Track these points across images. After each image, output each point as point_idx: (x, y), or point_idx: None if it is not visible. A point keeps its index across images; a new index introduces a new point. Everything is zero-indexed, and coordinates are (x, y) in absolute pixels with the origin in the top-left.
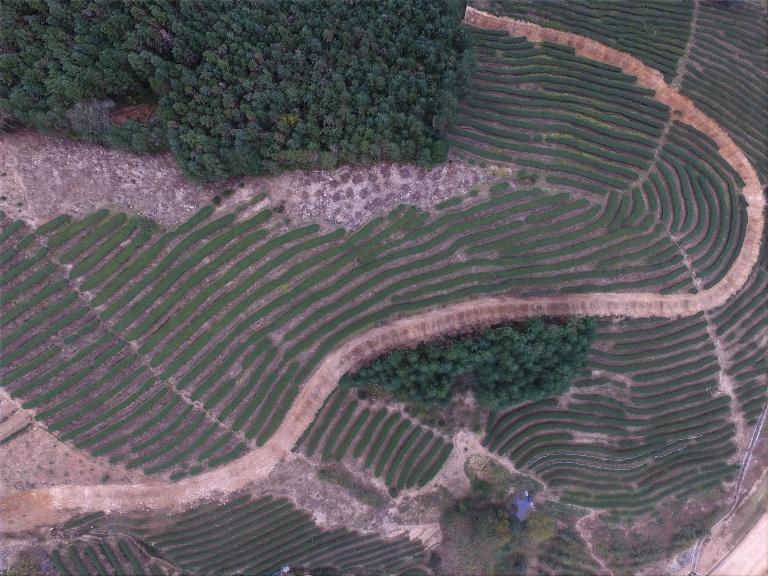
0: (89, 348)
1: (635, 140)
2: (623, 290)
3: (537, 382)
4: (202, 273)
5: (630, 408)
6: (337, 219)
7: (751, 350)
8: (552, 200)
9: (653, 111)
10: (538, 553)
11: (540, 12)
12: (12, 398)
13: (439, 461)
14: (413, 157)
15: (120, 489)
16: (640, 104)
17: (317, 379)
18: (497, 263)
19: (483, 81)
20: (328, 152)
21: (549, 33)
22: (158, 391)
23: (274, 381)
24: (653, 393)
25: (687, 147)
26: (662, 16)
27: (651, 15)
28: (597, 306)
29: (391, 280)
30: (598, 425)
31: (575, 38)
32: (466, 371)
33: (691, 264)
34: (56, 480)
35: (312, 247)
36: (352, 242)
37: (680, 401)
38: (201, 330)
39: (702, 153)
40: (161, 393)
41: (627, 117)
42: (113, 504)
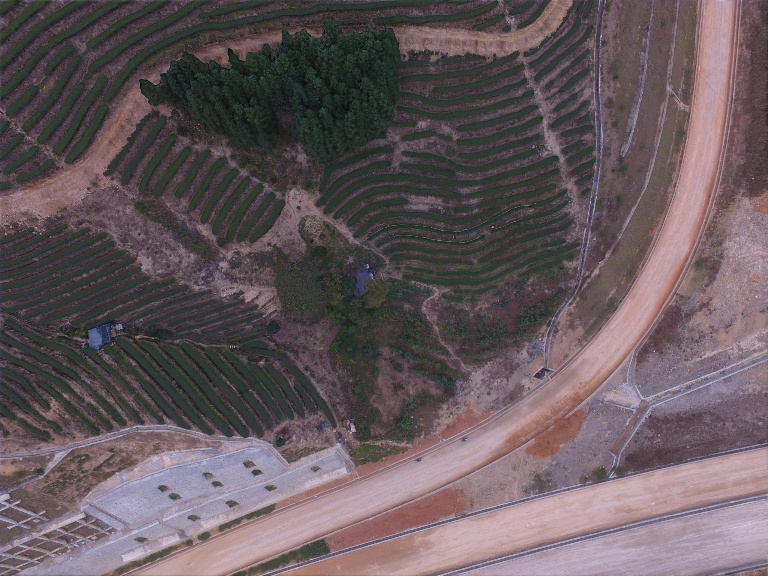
0: None
1: None
2: (436, 24)
3: (347, 108)
4: None
5: (459, 165)
6: None
7: (573, 102)
8: None
9: None
10: (389, 342)
11: None
12: None
13: (270, 216)
14: None
15: None
16: None
17: (130, 103)
18: None
19: None
20: None
21: None
22: None
23: (81, 95)
24: (480, 149)
25: None
26: None
27: None
28: (412, 41)
29: None
30: (431, 188)
31: None
32: (273, 90)
33: None
34: None
35: None
36: None
37: (507, 158)
38: None
39: None
40: None
41: None
42: None
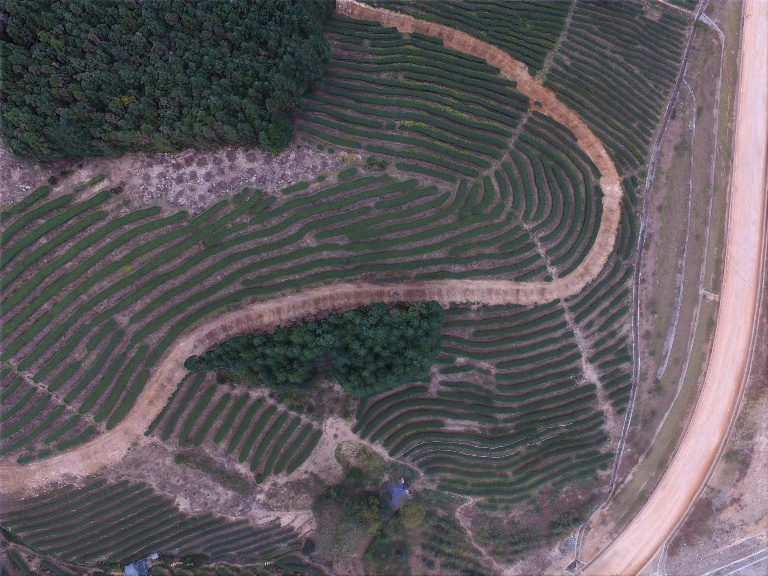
0: None
1: (490, 129)
2: (478, 277)
3: (390, 367)
4: (37, 253)
5: (497, 395)
6: (179, 201)
7: (611, 338)
8: (400, 186)
9: (511, 102)
10: (421, 541)
11: (417, 4)
12: None
13: (307, 447)
14: (256, 141)
15: None
16: (500, 95)
17: (171, 363)
18: (347, 248)
19: (345, 69)
20: (158, 133)
21: (421, 24)
22: None
23: (123, 364)
24: (518, 380)
25: (543, 137)
26: (538, 11)
27: (527, 10)
28: (453, 293)
29: (240, 264)
30: (468, 412)
31: (445, 30)
32: (317, 355)
33: (545, 252)
34: None
35: (153, 229)
36: (194, 225)
37: (545, 389)
38: (41, 311)
39: (558, 143)
40: (1, 374)
41: (485, 107)
42: None
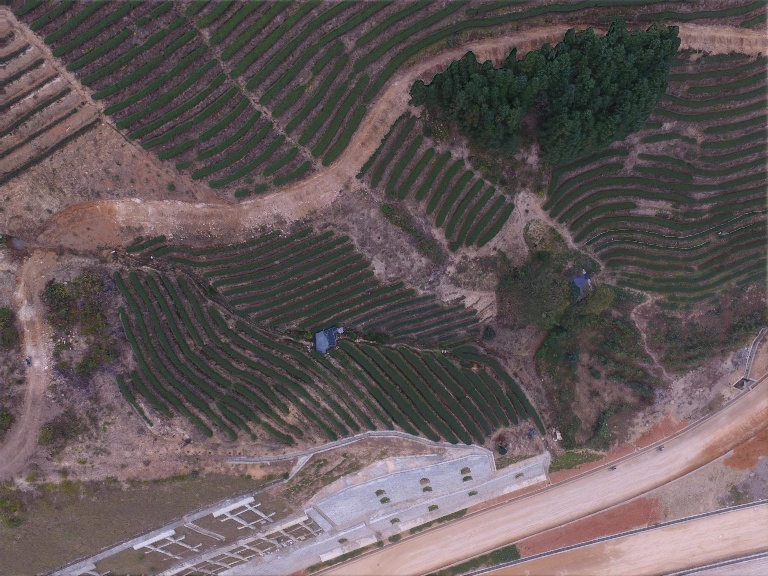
0: (161, 32)
1: None
2: (703, 20)
3: (611, 110)
4: None
5: (699, 169)
6: None
7: None
8: None
9: None
10: (589, 348)
11: None
12: (82, 88)
13: (499, 220)
14: None
15: (183, 209)
16: None
17: (384, 104)
18: None
19: None
20: None
21: None
22: (227, 91)
23: (343, 95)
24: (724, 152)
25: None
26: None
27: None
28: None
29: None
30: (663, 192)
31: None
32: (539, 91)
33: None
34: (121, 190)
35: None
36: None
37: (751, 162)
38: (273, 24)
39: None
40: (231, 92)
41: None
42: (176, 223)
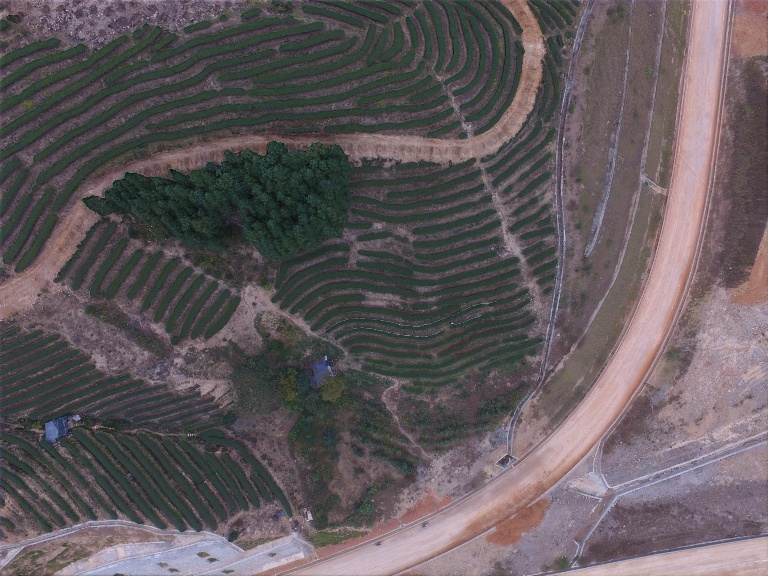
0: None
1: None
2: (389, 131)
3: (296, 219)
4: None
5: (416, 265)
6: (79, 35)
7: (533, 206)
8: (305, 28)
9: None
10: (349, 427)
11: None
12: None
13: (225, 313)
14: None
15: None
16: None
17: (80, 211)
18: (251, 93)
19: None
20: None
21: None
22: None
23: (30, 206)
24: (438, 250)
25: None
26: None
27: None
28: (365, 148)
29: (143, 106)
30: (389, 285)
31: None
32: (221, 202)
33: (459, 107)
34: None
35: (53, 62)
36: (93, 59)
37: (465, 259)
38: None
39: None
40: None
41: None
42: None
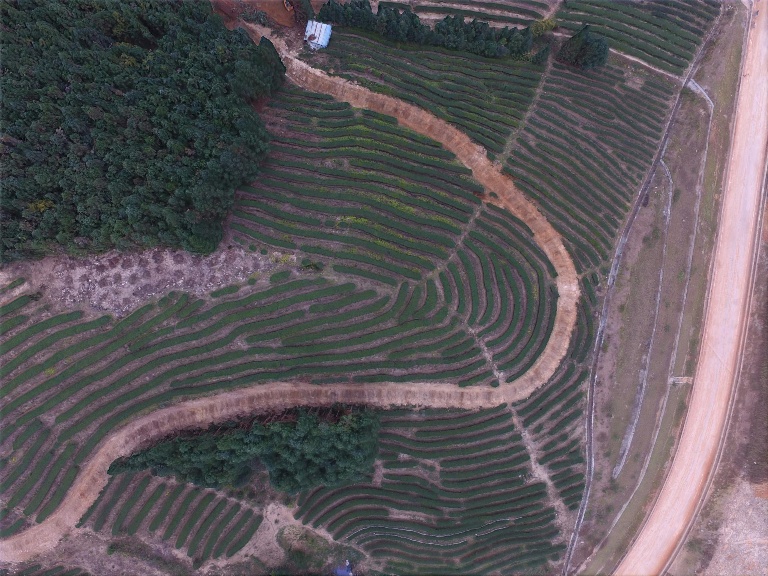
0: None
1: (438, 226)
2: (420, 380)
3: (324, 471)
4: None
5: (441, 490)
6: (103, 305)
7: (563, 441)
8: (336, 290)
9: (464, 193)
10: None
11: (375, 72)
12: None
13: (247, 533)
14: None
15: None
16: (453, 184)
17: (102, 457)
18: (279, 352)
19: (288, 154)
20: (72, 245)
21: (376, 99)
22: None
23: (51, 460)
24: None
25: (496, 234)
26: (506, 80)
27: (495, 79)
28: (394, 394)
29: (168, 365)
30: (413, 503)
31: (401, 106)
32: None
33: (491, 357)
34: None
35: (76, 333)
36: (118, 330)
37: (492, 486)
38: None
39: (512, 240)
40: None
41: (435, 199)
42: None
